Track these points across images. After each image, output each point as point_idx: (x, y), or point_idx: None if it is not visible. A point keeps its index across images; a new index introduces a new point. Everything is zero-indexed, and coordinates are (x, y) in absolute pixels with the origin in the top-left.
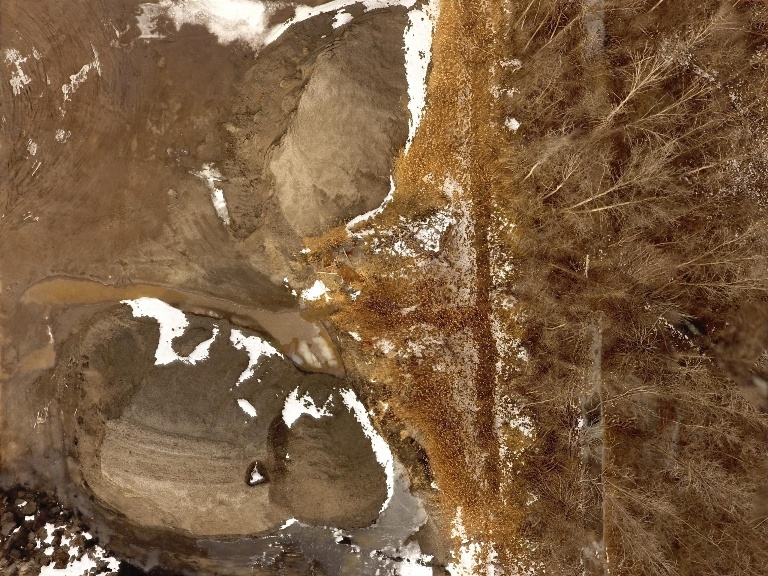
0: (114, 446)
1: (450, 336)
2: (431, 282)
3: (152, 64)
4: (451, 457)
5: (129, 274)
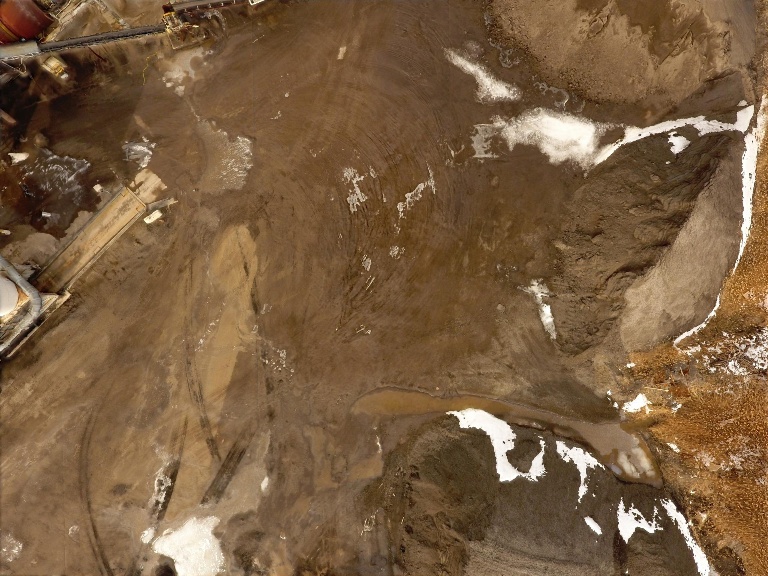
0: (483, 569)
1: (766, 448)
2: (752, 396)
3: (485, 183)
4: (767, 567)
5: (456, 386)
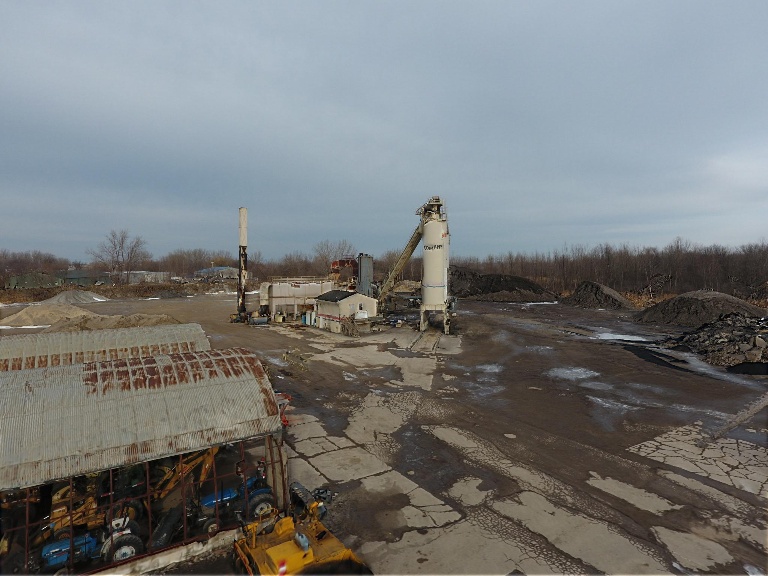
0: None
1: None
2: None
3: None
4: None
5: None
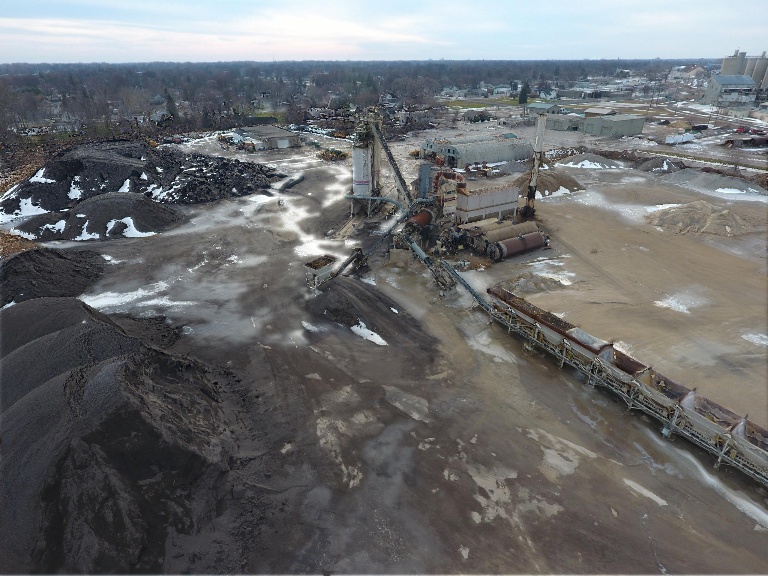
0: None
1: None
2: None
3: None
4: None
5: None
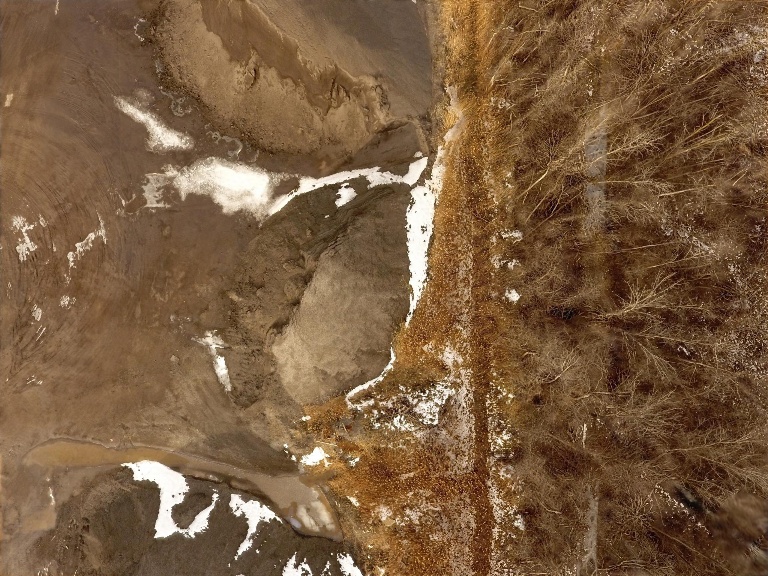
0: None
1: (447, 502)
2: (429, 450)
3: (157, 233)
4: None
5: (131, 438)
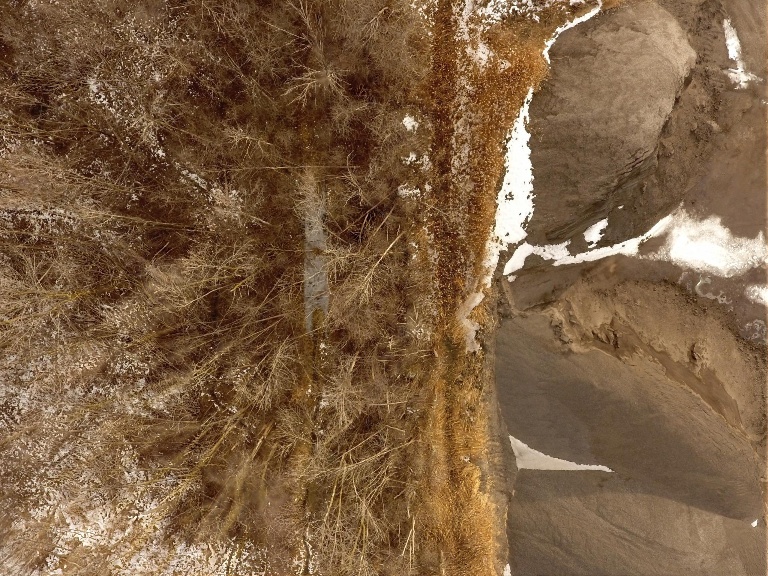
0: None
1: None
2: None
3: None
4: None
5: None
